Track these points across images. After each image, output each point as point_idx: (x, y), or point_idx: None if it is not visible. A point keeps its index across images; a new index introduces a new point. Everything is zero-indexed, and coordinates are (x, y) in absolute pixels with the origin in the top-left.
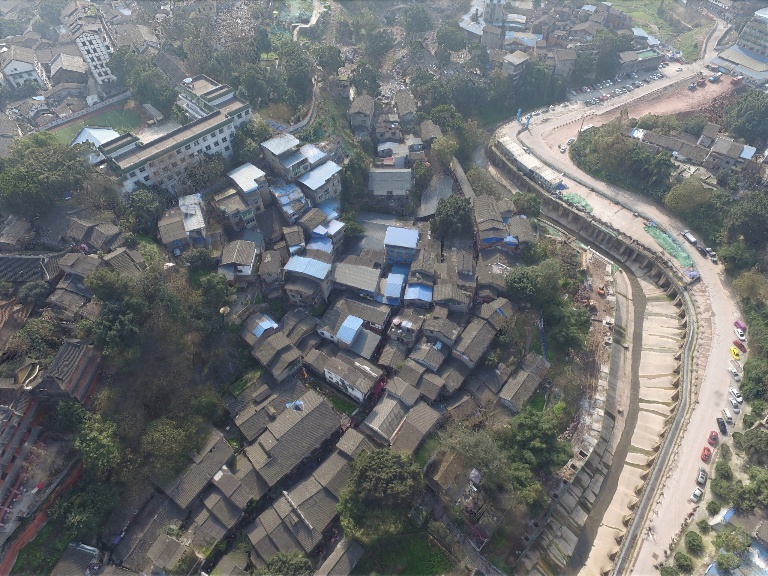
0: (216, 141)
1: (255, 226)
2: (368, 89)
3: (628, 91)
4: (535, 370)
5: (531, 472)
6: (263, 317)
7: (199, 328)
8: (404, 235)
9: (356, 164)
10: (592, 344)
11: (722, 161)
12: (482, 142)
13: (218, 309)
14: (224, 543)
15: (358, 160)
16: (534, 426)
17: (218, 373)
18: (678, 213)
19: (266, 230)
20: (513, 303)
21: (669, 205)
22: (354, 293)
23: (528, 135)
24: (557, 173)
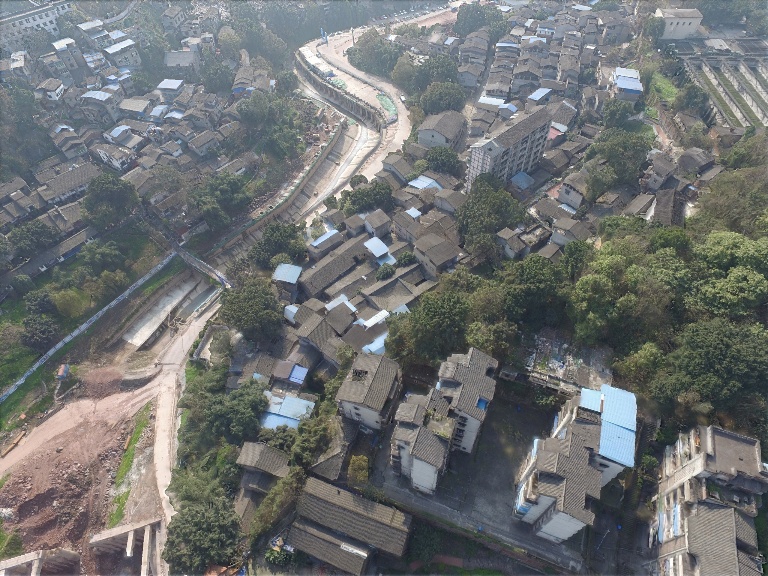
0: (44, 22)
1: (69, 76)
2: (179, 3)
3: (415, 17)
4: (245, 159)
5: (218, 202)
6: (64, 124)
7: (13, 120)
8: (172, 83)
9: (153, 45)
10: (306, 156)
11: (436, 49)
12: (277, 46)
13: (32, 116)
14: (12, 226)
15: (155, 42)
16: (224, 178)
17: (29, 153)
18: (401, 85)
19: (78, 80)
20: (242, 124)
21: (393, 79)
22: (133, 117)
23: (325, 46)
24: (334, 68)
